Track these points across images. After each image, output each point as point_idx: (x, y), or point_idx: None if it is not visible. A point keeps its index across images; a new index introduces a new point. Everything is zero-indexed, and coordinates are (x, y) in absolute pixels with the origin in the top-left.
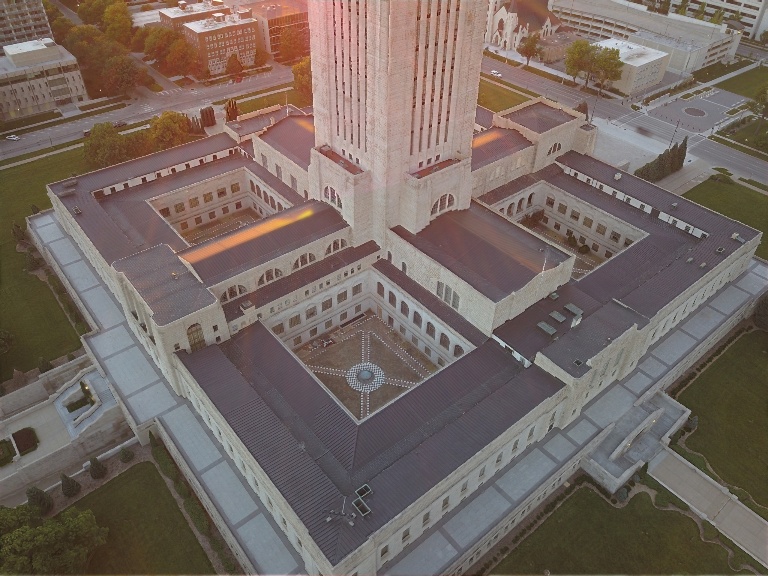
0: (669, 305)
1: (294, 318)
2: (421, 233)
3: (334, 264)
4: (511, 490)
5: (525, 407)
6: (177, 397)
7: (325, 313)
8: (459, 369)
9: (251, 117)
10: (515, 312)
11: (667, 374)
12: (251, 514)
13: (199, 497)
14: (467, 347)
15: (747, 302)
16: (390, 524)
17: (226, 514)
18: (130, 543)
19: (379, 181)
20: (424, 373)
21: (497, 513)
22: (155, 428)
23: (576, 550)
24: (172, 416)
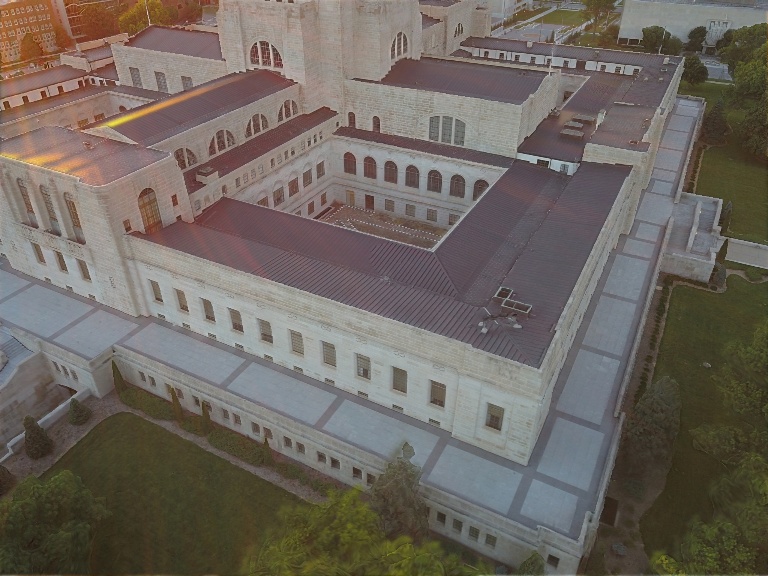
0: (662, 104)
1: (261, 203)
2: (386, 79)
3: (292, 131)
4: (625, 293)
5: (610, 190)
6: (135, 319)
7: (292, 200)
8: (505, 187)
9: (94, 47)
10: (531, 127)
11: (683, 174)
12: (332, 405)
13: (231, 422)
14: (494, 174)
15: (697, 120)
16: (567, 311)
17: (294, 416)
18: (144, 518)
19: (329, 11)
20: (438, 238)
21: (629, 315)
22: (116, 364)
23: (716, 337)
24: (139, 339)
